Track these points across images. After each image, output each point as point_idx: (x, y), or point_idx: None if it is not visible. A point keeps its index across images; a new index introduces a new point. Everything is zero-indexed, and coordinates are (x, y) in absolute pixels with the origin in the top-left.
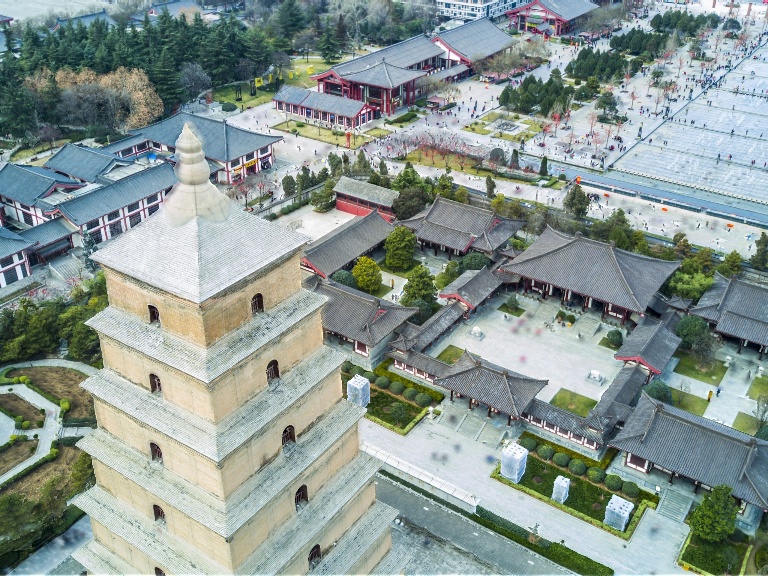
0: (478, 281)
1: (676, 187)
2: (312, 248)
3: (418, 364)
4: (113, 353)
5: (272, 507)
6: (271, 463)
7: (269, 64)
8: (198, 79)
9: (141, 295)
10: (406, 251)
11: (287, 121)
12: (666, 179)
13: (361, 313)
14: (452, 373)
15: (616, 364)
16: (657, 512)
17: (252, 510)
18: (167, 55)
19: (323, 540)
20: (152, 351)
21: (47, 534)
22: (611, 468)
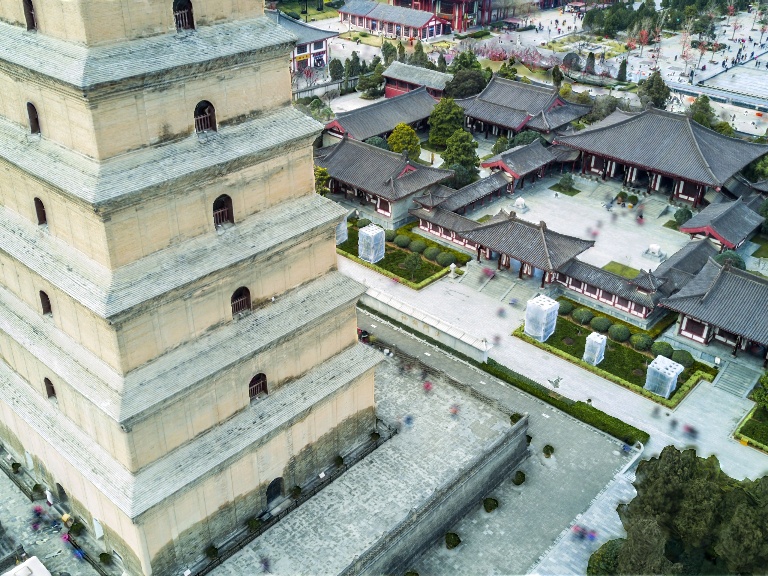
0: (528, 153)
1: None
2: (345, 112)
3: (445, 222)
4: None
5: (175, 203)
6: (176, 142)
7: None
8: None
9: None
10: (451, 125)
11: (350, 30)
12: (764, 96)
13: (387, 168)
14: None
15: (681, 244)
16: (713, 385)
17: (137, 183)
18: None
19: (254, 285)
20: None
21: None
22: (661, 338)
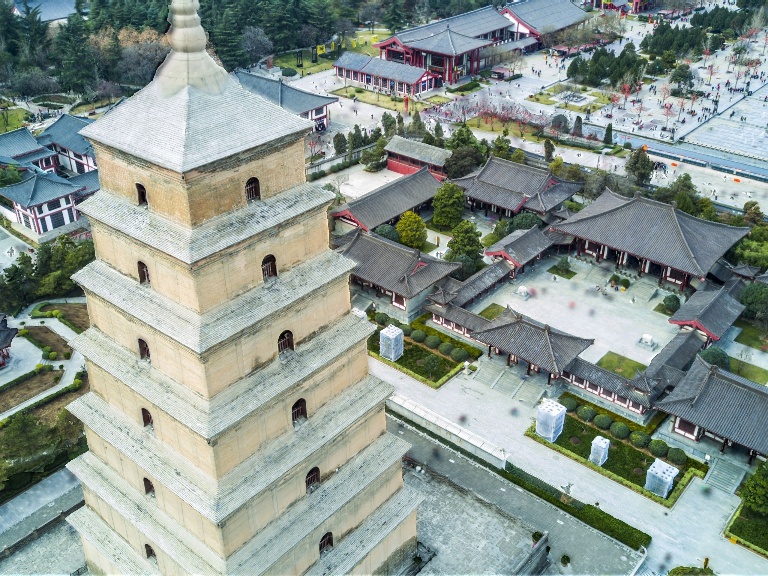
0: (527, 240)
1: (752, 161)
2: (356, 201)
3: (456, 318)
4: (103, 241)
5: (264, 416)
6: (264, 368)
7: (333, 33)
8: (259, 43)
9: (129, 173)
10: (454, 209)
11: (346, 87)
12: (741, 153)
13: (400, 264)
14: (491, 327)
15: (671, 330)
16: (705, 481)
17: (239, 414)
18: (229, 17)
19: (323, 463)
20: (137, 233)
21: (61, 460)
22: (657, 434)
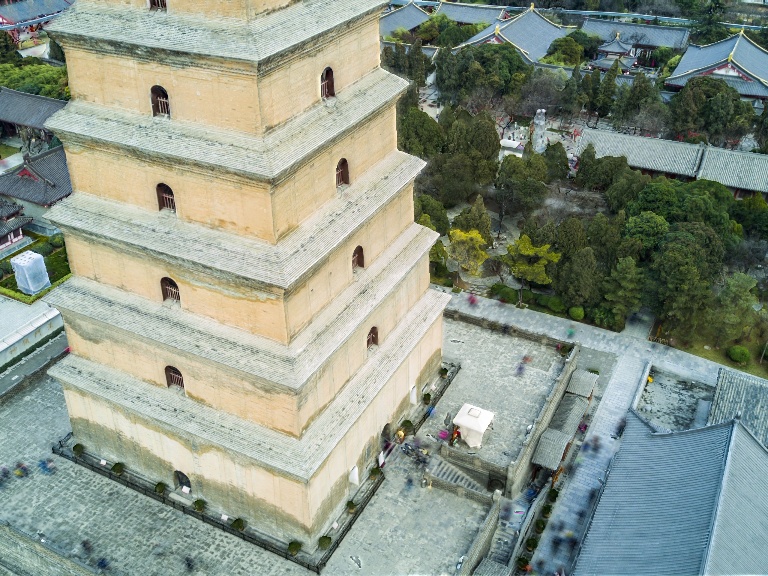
0: None
1: None
2: None
3: None
4: None
5: None
6: None
7: None
8: None
9: None
10: None
11: None
12: None
13: None
14: None
15: None
16: None
17: None
18: None
19: None
20: None
21: None
22: None
